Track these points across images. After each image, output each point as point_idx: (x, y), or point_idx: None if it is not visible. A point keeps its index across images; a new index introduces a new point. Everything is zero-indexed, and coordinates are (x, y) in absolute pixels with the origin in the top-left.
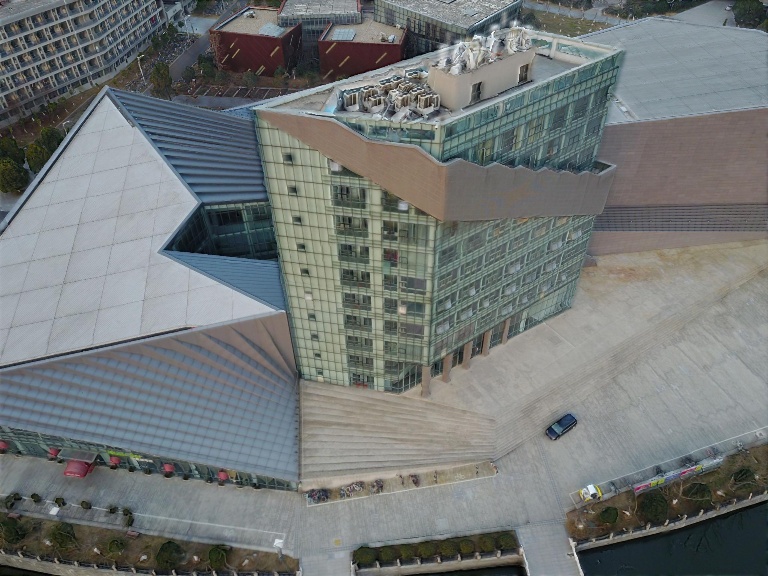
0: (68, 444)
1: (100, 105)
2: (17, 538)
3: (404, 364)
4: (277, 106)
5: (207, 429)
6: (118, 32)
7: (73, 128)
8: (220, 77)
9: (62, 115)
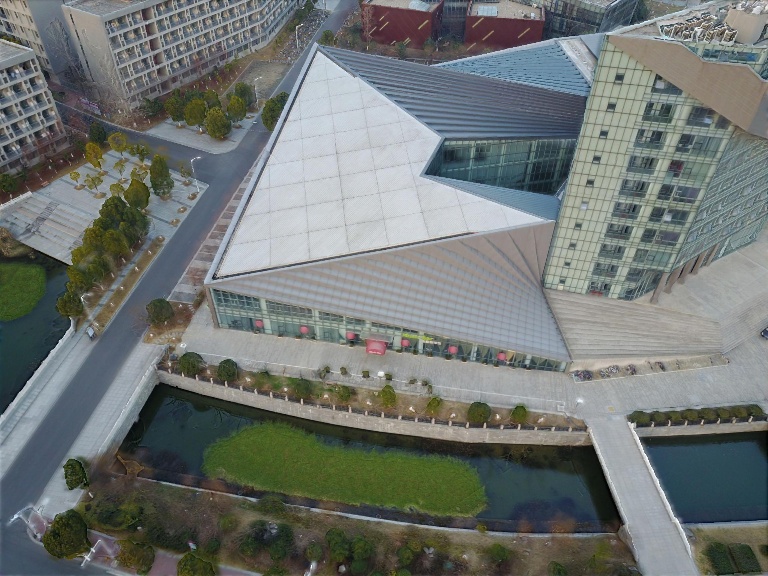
0: (368, 328)
1: (316, 59)
2: (349, 395)
3: (645, 272)
4: None
5: (486, 318)
6: (272, 4)
7: (299, 77)
8: (373, 46)
9: (233, 76)
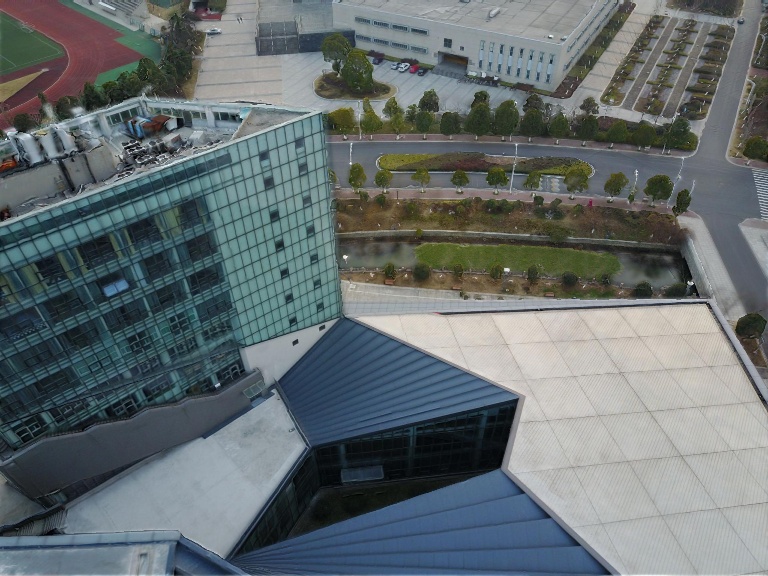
0: None
1: None
2: None
3: None
4: None
5: None
6: None
7: None
8: None
9: None
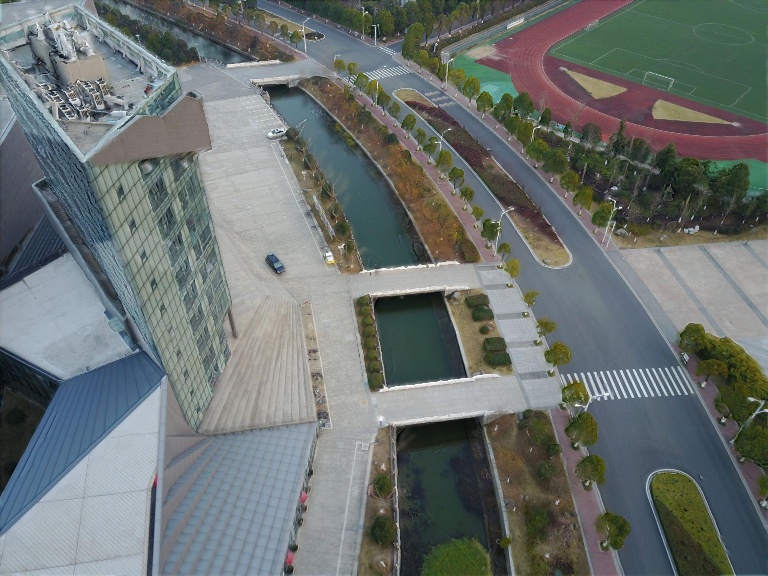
0: None
1: None
2: None
3: None
4: (81, 151)
5: (259, 503)
6: None
7: None
8: None
9: None
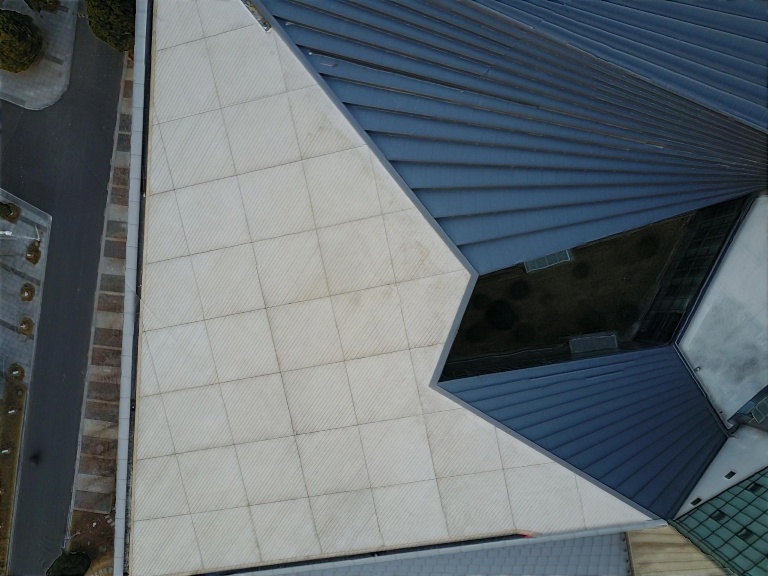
0: None
1: None
2: None
3: None
4: None
5: None
6: None
7: (137, 27)
8: None
9: None
